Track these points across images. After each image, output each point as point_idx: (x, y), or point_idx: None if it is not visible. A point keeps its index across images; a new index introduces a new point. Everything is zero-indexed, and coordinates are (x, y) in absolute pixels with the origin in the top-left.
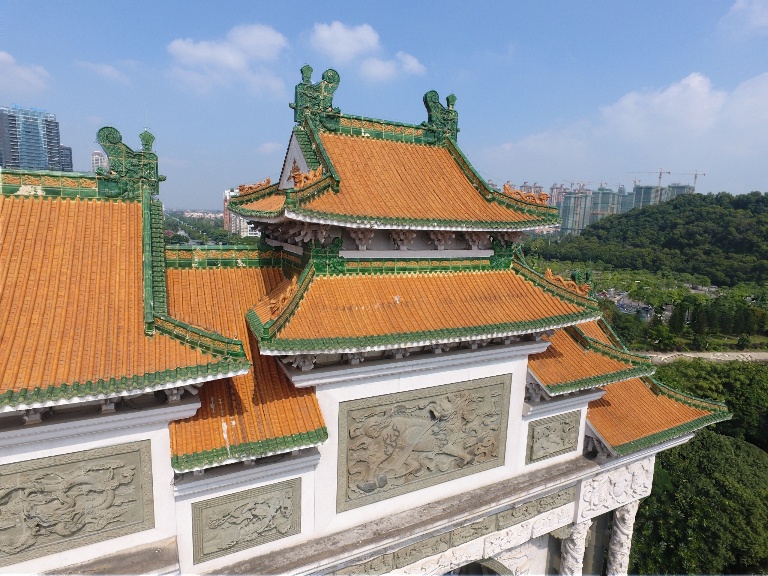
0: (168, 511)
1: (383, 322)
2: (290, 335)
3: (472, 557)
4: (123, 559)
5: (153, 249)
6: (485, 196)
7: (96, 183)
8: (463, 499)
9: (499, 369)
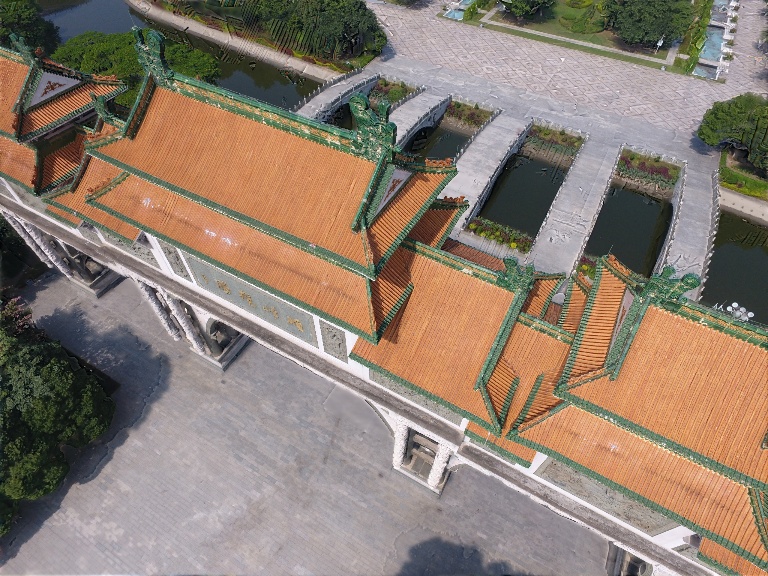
0: (465, 427)
1: (588, 456)
2: (526, 436)
3: None
4: (447, 427)
5: (504, 332)
6: (764, 442)
7: (497, 278)
8: (607, 524)
9: None
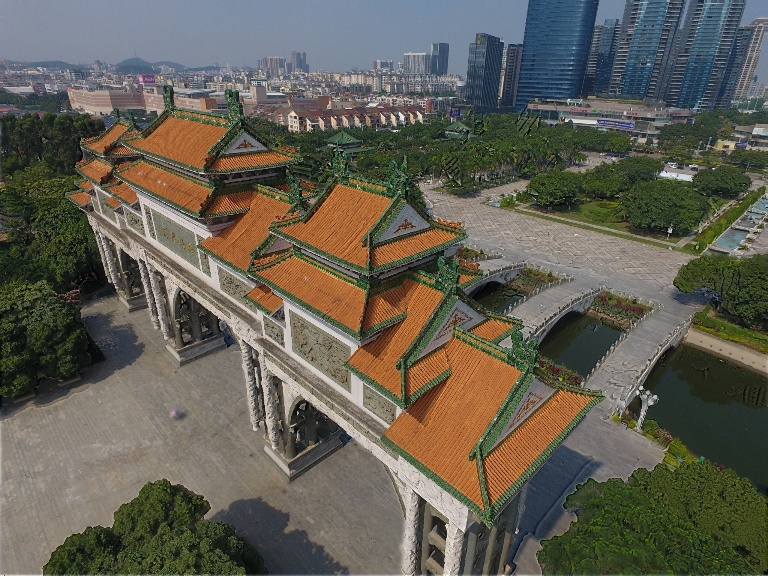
0: None
1: None
2: None
3: (340, 425)
4: None
5: None
6: None
7: None
8: (328, 389)
9: (344, 340)
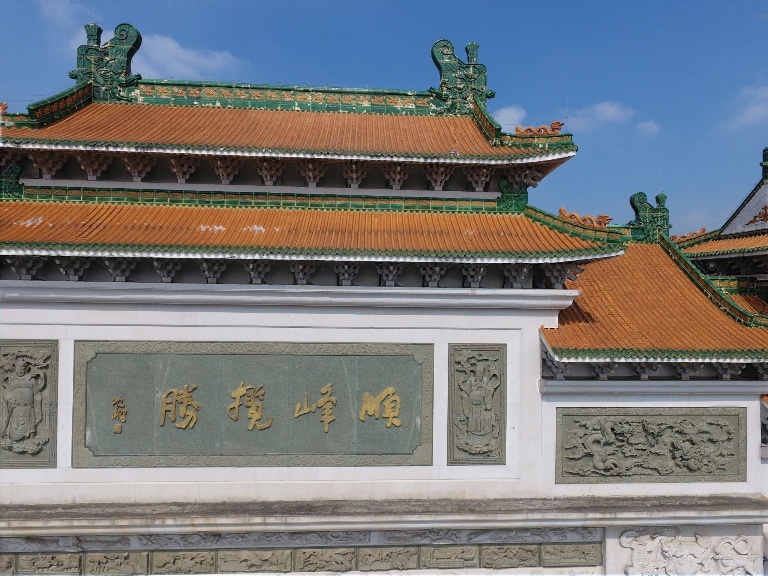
0: (756, 470)
1: None
2: None
3: None
4: (731, 499)
5: None
6: None
7: (630, 231)
8: None
9: None
